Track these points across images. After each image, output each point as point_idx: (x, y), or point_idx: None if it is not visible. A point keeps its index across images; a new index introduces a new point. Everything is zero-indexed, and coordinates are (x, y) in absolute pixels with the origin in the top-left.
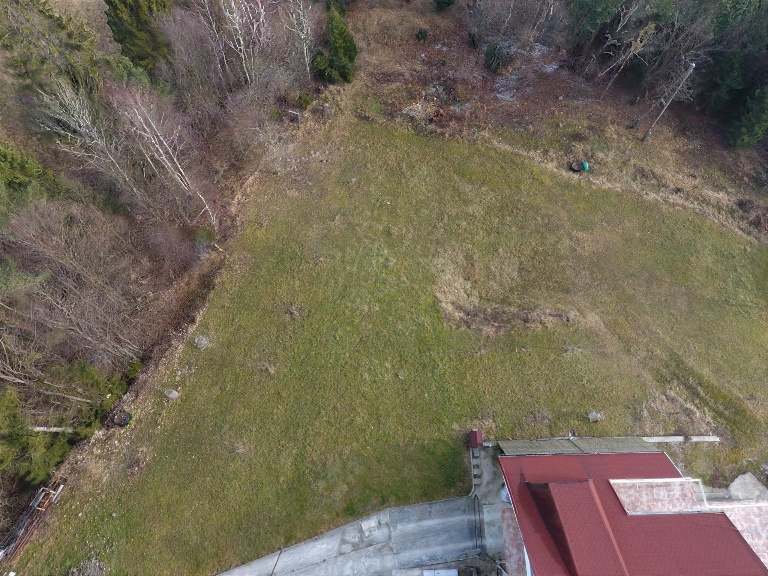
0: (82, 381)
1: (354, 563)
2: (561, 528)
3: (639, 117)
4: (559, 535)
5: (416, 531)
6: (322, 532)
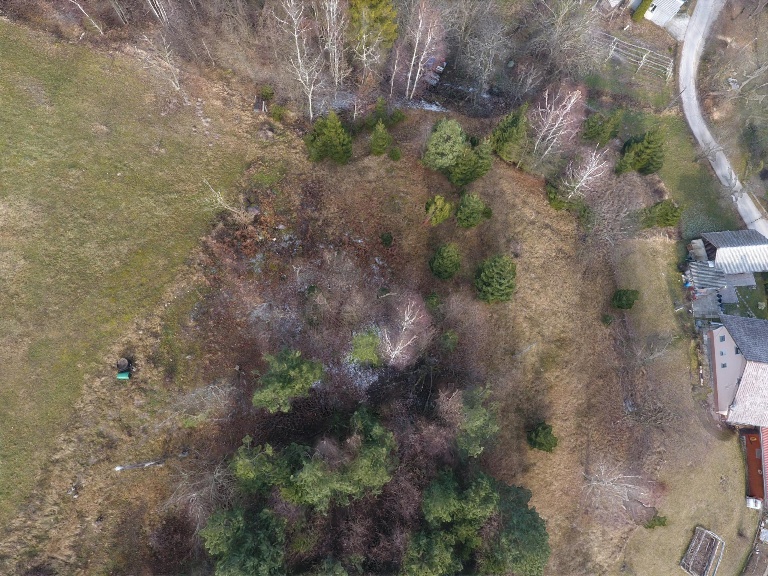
0: None
1: None
2: None
3: None
4: None
5: None
6: None
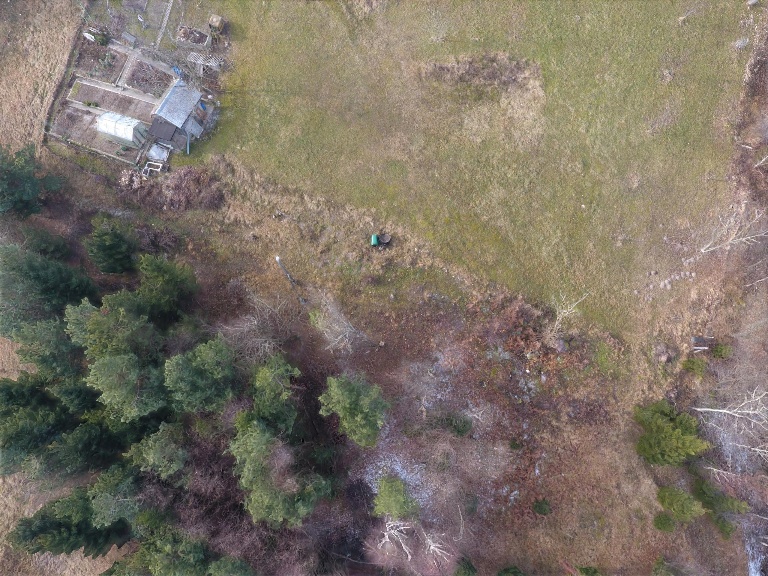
0: None
1: None
2: None
3: None
4: None
5: None
6: None
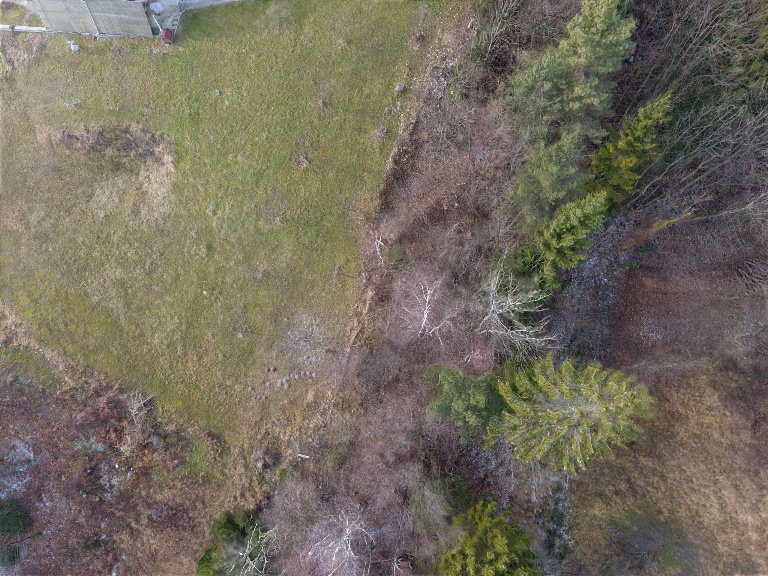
0: None
1: None
2: None
3: None
4: None
5: None
6: None
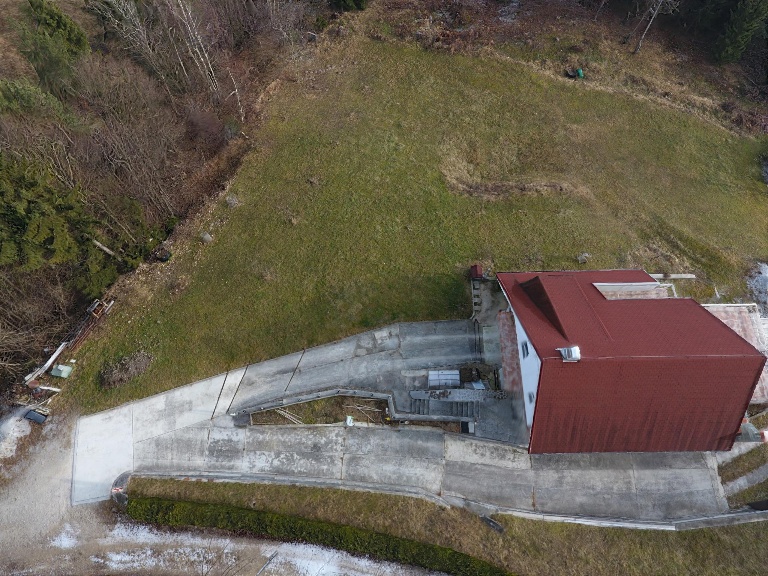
0: (130, 216)
1: (368, 364)
2: (548, 300)
3: (631, 35)
4: (546, 306)
5: (423, 343)
6: (340, 338)
